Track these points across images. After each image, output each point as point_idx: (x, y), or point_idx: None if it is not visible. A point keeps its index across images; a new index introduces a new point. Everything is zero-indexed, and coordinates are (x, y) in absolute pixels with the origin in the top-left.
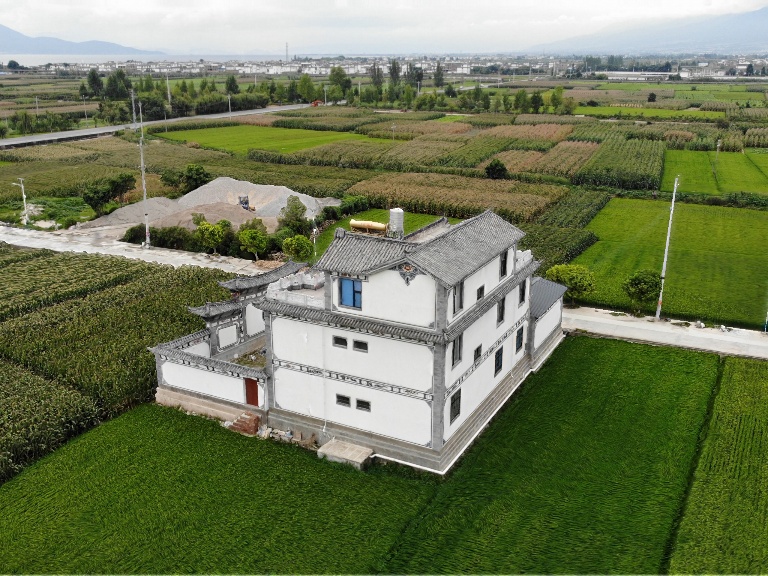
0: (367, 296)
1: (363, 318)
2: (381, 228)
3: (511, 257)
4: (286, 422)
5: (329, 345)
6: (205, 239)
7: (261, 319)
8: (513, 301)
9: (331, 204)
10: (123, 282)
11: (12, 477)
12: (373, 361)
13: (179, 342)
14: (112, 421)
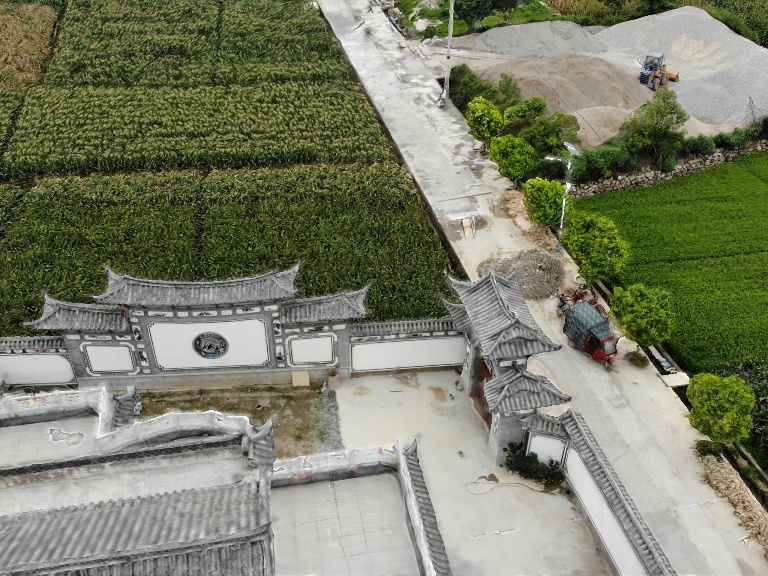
0: None
1: None
2: None
3: None
4: None
5: None
6: None
7: (192, 350)
8: None
9: None
10: (309, 158)
11: None
12: None
13: (0, 344)
14: None
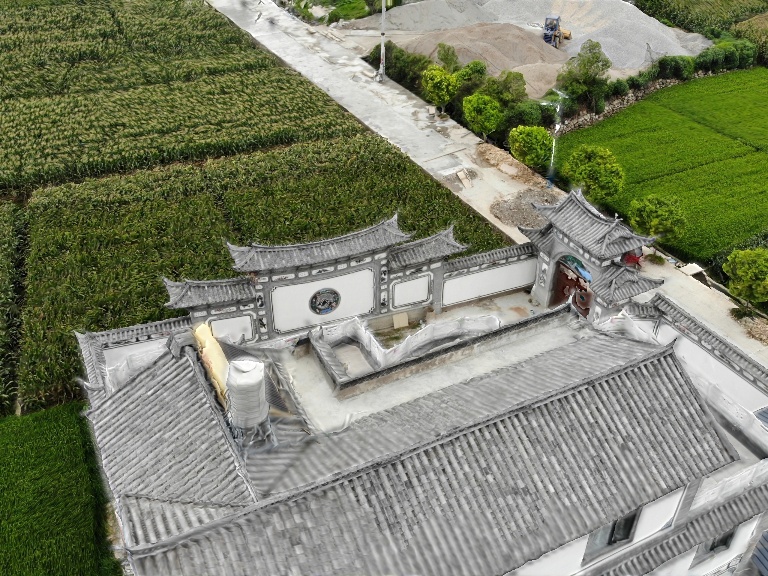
0: None
1: None
2: (223, 389)
3: (668, 498)
4: None
5: None
6: None
7: (307, 309)
8: (664, 567)
9: (694, 47)
10: (287, 139)
11: None
12: None
13: (127, 334)
14: (3, 425)
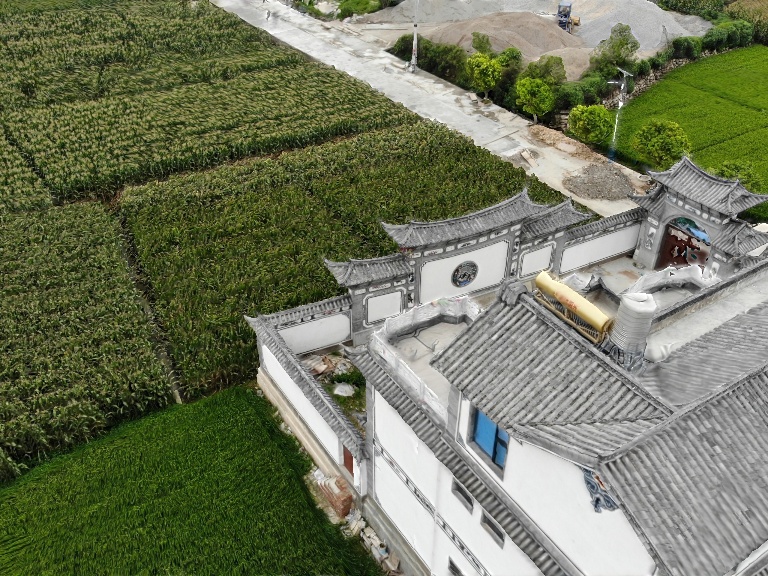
0: (515, 466)
1: (502, 494)
2: (594, 323)
3: None
4: (383, 531)
5: (446, 486)
6: (475, 78)
7: (449, 283)
8: None
9: (694, 28)
10: (346, 130)
11: (15, 477)
12: (509, 567)
13: (295, 315)
14: (176, 413)
